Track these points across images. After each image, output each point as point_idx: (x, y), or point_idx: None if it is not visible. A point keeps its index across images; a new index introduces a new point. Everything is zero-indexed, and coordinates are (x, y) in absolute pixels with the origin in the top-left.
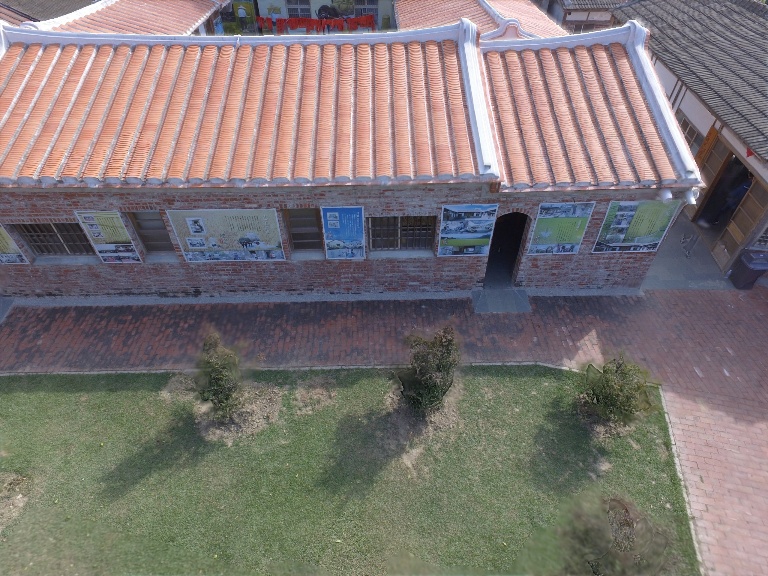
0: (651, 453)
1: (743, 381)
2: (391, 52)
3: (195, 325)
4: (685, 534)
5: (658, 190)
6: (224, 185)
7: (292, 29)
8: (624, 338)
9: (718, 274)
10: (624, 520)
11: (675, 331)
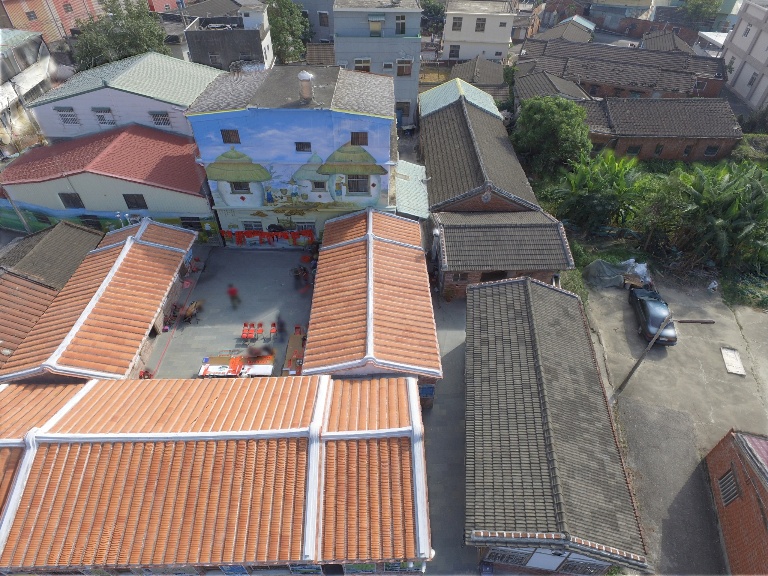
0: None
1: None
2: (268, 446)
3: None
4: None
5: None
6: (161, 566)
7: (248, 237)
8: None
9: (475, 565)
10: None
11: None
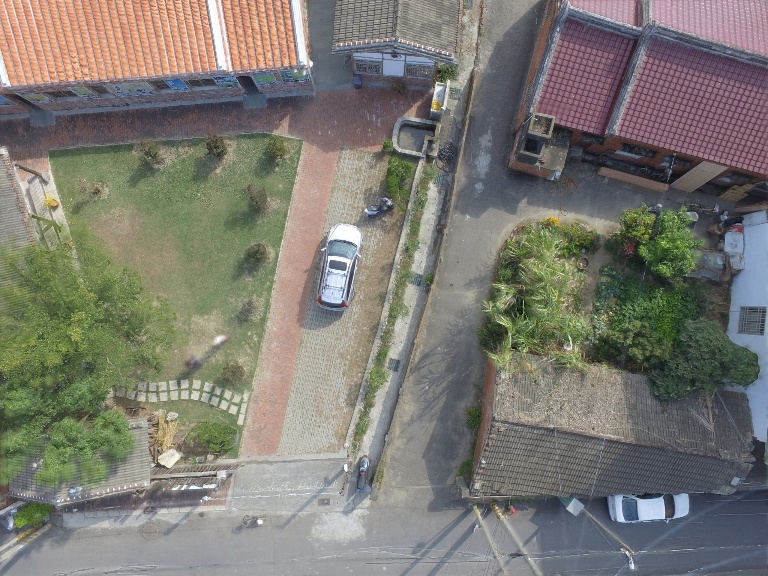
0: (292, 164)
1: (333, 136)
2: None
3: (133, 121)
4: (292, 187)
5: (292, 68)
6: (123, 80)
7: None
8: (299, 118)
9: None
10: (249, 189)
11: (320, 114)
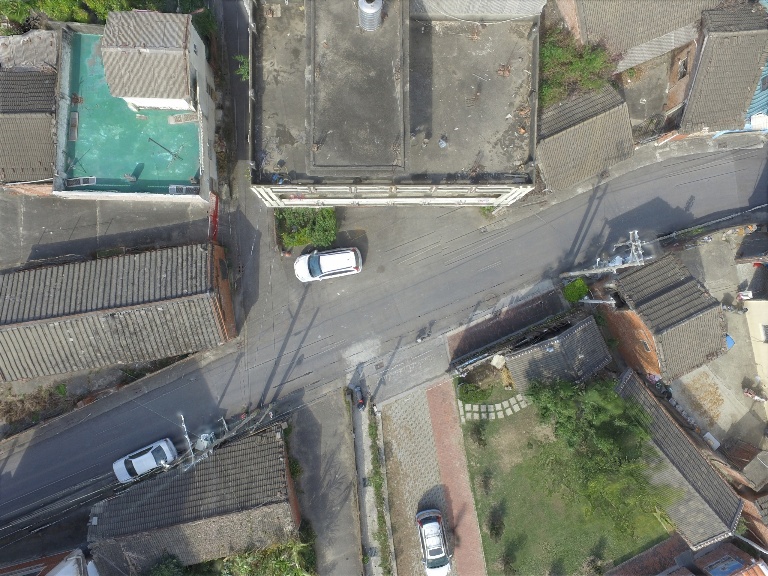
0: None
1: None
2: None
3: None
4: None
5: None
6: None
7: None
8: None
9: None
10: None
11: None
